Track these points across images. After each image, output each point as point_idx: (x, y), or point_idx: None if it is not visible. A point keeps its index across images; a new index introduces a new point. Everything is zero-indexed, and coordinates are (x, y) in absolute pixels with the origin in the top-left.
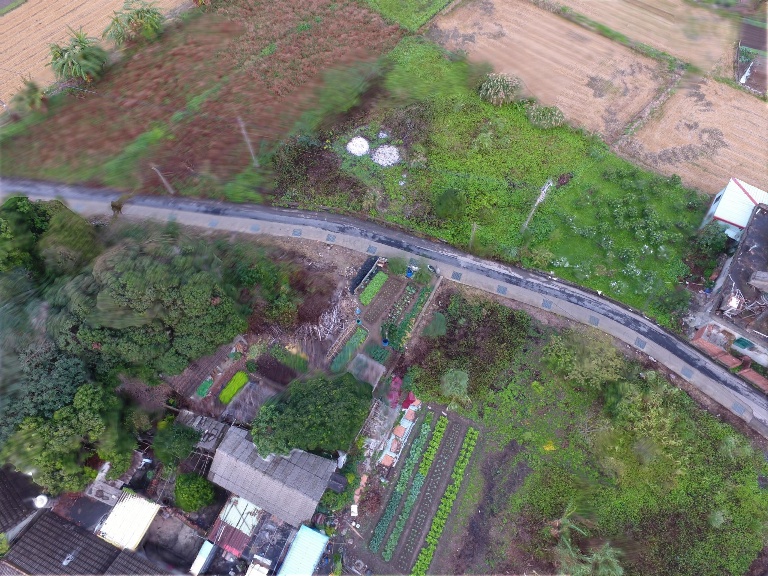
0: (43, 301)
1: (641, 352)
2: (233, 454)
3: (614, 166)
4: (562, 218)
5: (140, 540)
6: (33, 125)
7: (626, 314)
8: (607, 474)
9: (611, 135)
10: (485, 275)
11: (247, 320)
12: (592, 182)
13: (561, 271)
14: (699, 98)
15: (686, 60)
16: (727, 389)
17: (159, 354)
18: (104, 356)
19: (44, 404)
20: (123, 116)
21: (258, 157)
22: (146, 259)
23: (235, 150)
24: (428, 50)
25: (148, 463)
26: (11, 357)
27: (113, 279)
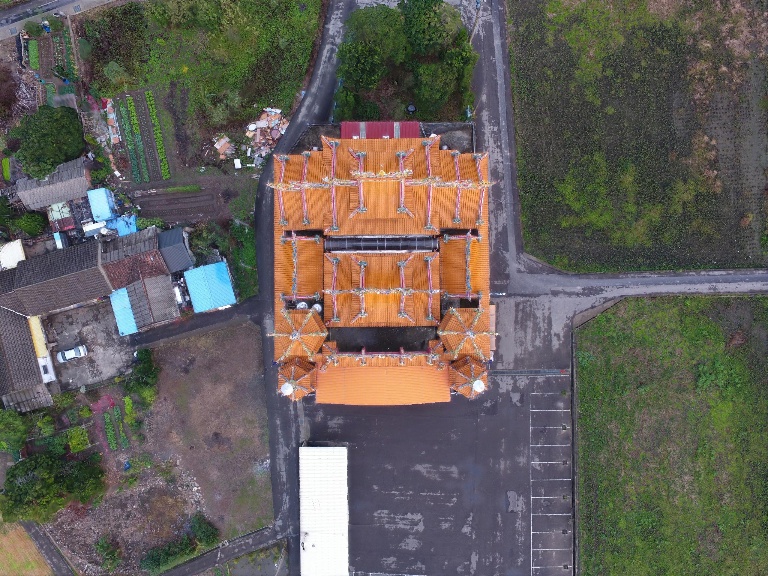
0: None
1: None
2: (27, 189)
3: None
4: None
5: (25, 257)
6: None
7: None
8: (226, 63)
9: None
10: None
11: None
12: None
13: None
14: None
15: None
16: None
17: None
18: None
19: None
20: None
21: None
22: None
23: None
24: None
25: (1, 234)
26: None
27: None
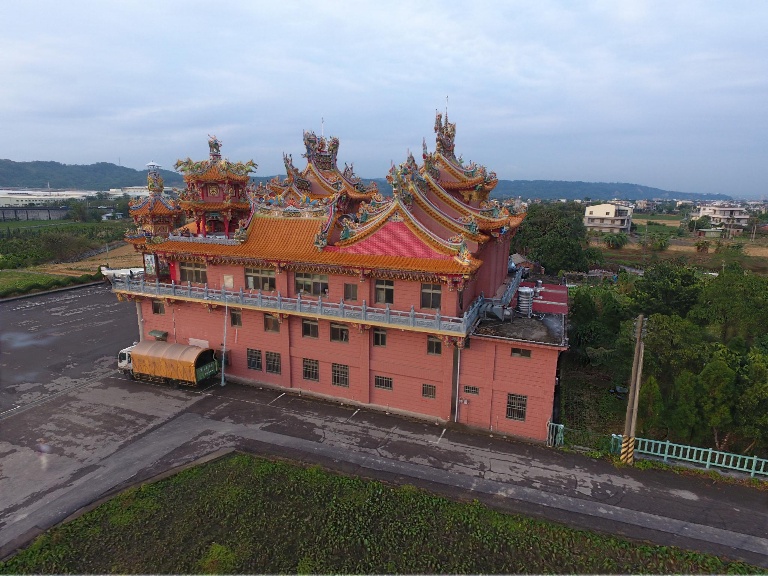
0: None
1: None
2: None
3: None
4: None
5: None
6: None
7: None
8: None
9: None
10: None
11: None
12: None
13: None
14: None
15: None
16: None
17: None
18: None
19: None
20: None
21: None
22: None
23: None
24: None
25: None
26: None
27: None
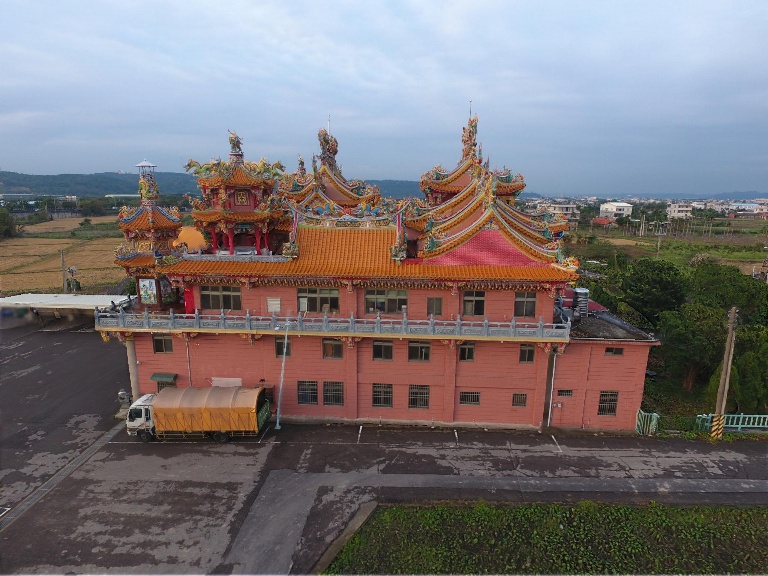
0: None
1: None
2: None
3: None
4: None
5: None
6: None
7: None
8: None
9: None
10: None
11: None
12: None
13: None
14: None
15: None
16: None
17: None
18: None
19: None
20: None
21: None
22: None
23: None
24: None
25: None
26: None
27: None
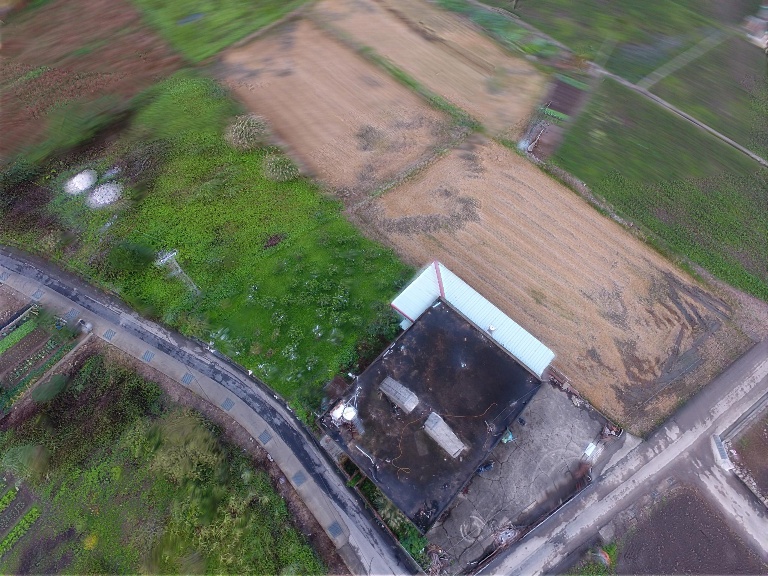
0: None
1: (262, 448)
2: None
3: (340, 230)
4: None
5: None
6: None
7: (266, 401)
8: None
9: (359, 194)
10: (139, 337)
11: None
12: (307, 246)
13: (222, 343)
14: (475, 163)
15: (482, 118)
16: (334, 505)
17: None
18: None
19: None
20: None
21: None
22: None
23: None
24: (206, 82)
25: None
26: None
27: None
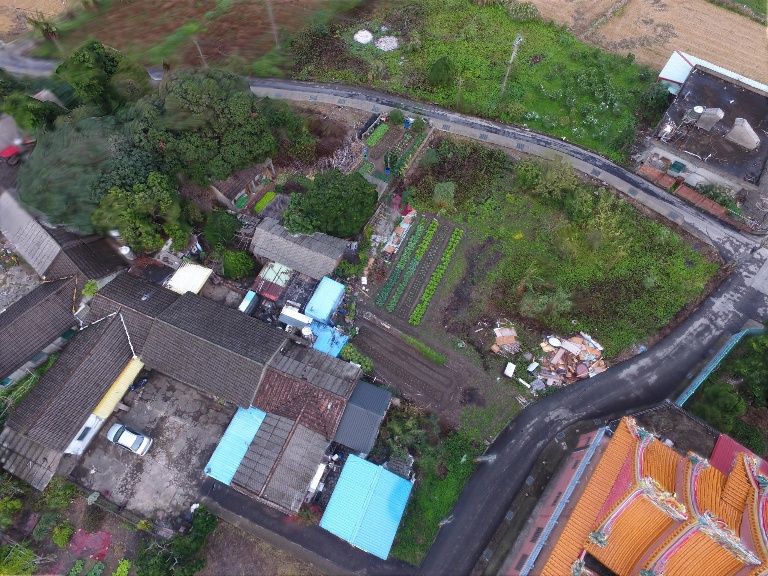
0: (117, 118)
1: (596, 179)
2: (269, 231)
3: None
4: (535, 87)
5: (198, 291)
6: (87, 22)
7: (585, 153)
8: (565, 258)
9: (579, 29)
10: (470, 127)
11: (275, 156)
12: None
13: (533, 124)
14: (656, 1)
15: None
16: (664, 203)
17: (210, 157)
18: (167, 158)
19: (126, 179)
20: (163, 15)
21: (279, 43)
22: (201, 75)
23: (259, 39)
24: None
25: (199, 251)
26: (102, 139)
27: (177, 86)
